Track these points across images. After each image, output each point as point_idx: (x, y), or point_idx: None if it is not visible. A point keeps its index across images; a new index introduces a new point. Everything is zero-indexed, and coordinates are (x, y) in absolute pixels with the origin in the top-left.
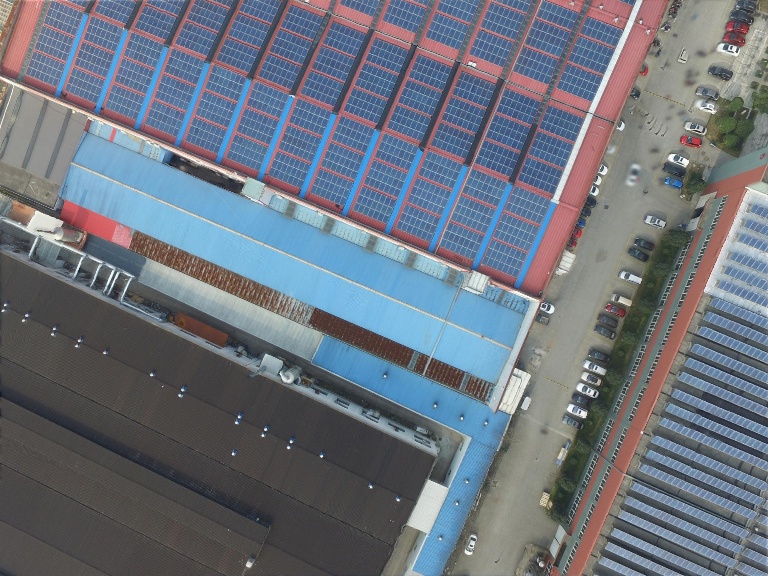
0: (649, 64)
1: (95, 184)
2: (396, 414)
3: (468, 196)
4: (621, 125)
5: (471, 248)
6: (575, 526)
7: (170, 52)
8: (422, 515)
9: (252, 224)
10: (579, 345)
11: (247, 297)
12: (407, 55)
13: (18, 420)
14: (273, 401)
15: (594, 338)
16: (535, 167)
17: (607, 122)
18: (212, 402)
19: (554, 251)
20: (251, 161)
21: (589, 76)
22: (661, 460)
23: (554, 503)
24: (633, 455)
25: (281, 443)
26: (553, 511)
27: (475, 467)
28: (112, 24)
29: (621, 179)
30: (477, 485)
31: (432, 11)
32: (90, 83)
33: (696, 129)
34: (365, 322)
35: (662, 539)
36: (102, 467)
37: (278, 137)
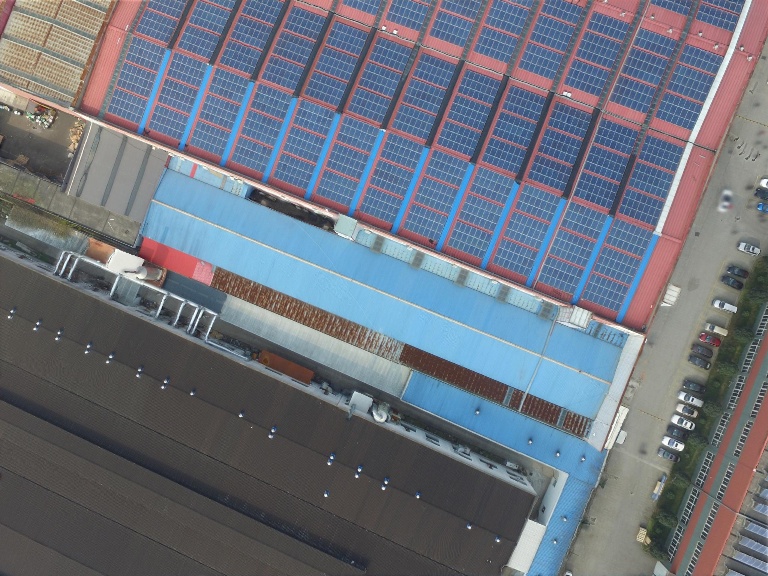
0: None
1: (177, 221)
2: (485, 449)
3: (567, 229)
4: None
5: (570, 282)
6: (679, 564)
7: (256, 87)
8: (520, 554)
9: (339, 259)
10: (672, 376)
11: (333, 333)
12: (499, 86)
13: (104, 464)
14: (366, 440)
15: (688, 368)
16: (636, 199)
17: (708, 151)
18: (303, 442)
19: (657, 284)
20: (341, 197)
21: (689, 105)
22: None
23: (652, 539)
24: (746, 493)
25: (375, 484)
26: (653, 548)
27: (572, 504)
28: (196, 60)
29: (712, 205)
30: (574, 522)
31: (524, 41)
32: (174, 120)
33: None
34: (457, 358)
35: None
36: (192, 511)
37: (369, 172)
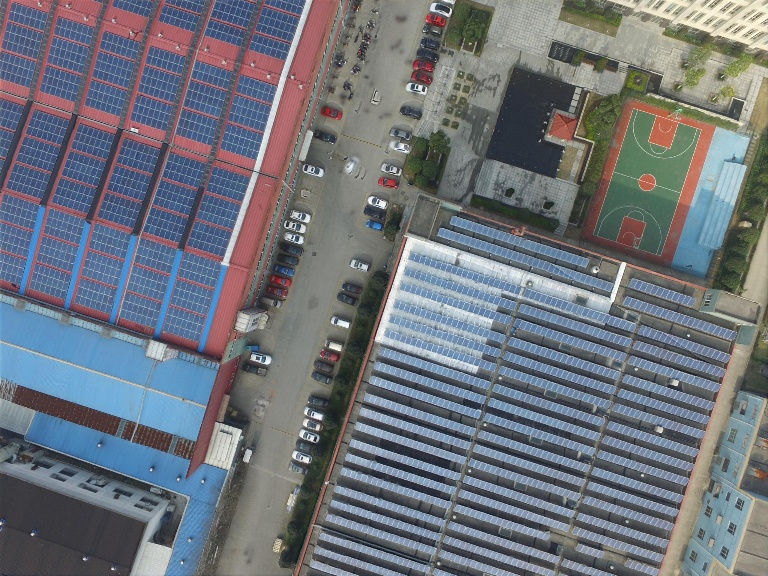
0: (343, 108)
1: None
2: None
3: (141, 265)
4: (319, 172)
5: (151, 316)
6: None
7: None
8: None
9: None
10: (299, 392)
11: None
12: (68, 125)
13: None
14: None
15: (313, 384)
16: (204, 231)
17: (273, 179)
18: None
19: (231, 313)
20: None
21: (250, 135)
22: (344, 508)
23: (285, 549)
24: (320, 505)
25: None
26: (280, 558)
27: (197, 525)
28: None
29: (326, 225)
30: (202, 542)
31: (88, 78)
32: None
33: (390, 171)
34: (69, 395)
35: None
36: None
37: None
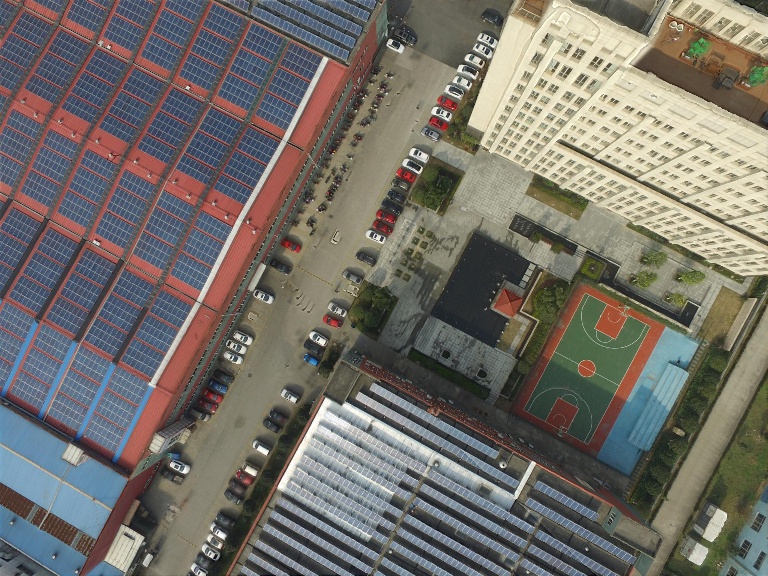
0: (304, 242)
1: None
2: None
3: (76, 370)
4: (268, 299)
5: (76, 419)
6: None
7: None
8: None
9: None
10: (210, 506)
11: None
12: (39, 228)
13: None
14: None
15: (225, 501)
16: (139, 350)
17: (213, 312)
18: None
19: (149, 431)
20: None
21: (200, 267)
22: None
23: None
24: None
25: None
26: None
27: None
28: None
29: (266, 350)
30: None
31: (65, 188)
32: None
33: (335, 311)
34: None
35: None
36: None
37: None
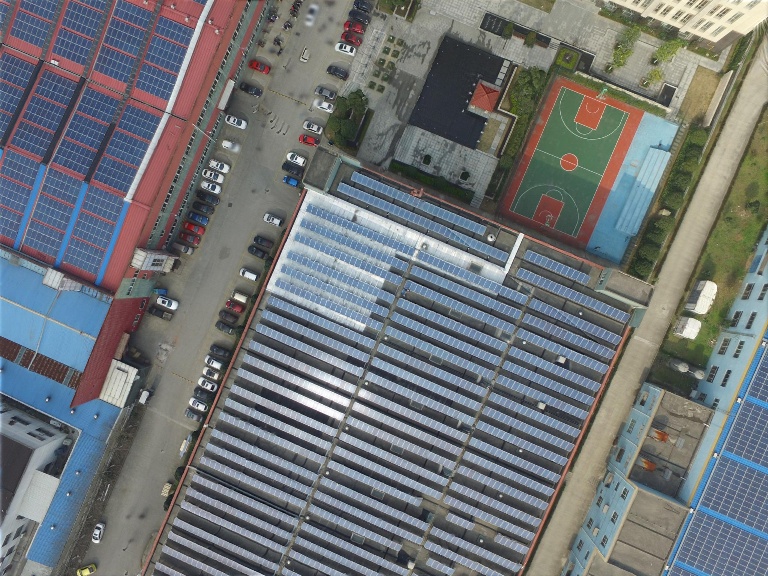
0: (272, 63)
1: None
2: (31, 408)
3: (47, 194)
4: (241, 124)
5: (53, 246)
6: None
7: None
8: (33, 505)
9: None
10: (203, 340)
11: None
12: None
13: None
14: None
15: (217, 333)
16: (110, 166)
17: (184, 122)
18: None
19: (130, 249)
20: None
21: (165, 76)
22: (219, 452)
23: (173, 493)
24: (197, 447)
25: None
26: (165, 501)
27: (87, 459)
28: None
29: (244, 177)
30: (90, 476)
31: (15, 8)
32: None
33: (311, 128)
34: None
35: (222, 528)
36: None
37: None
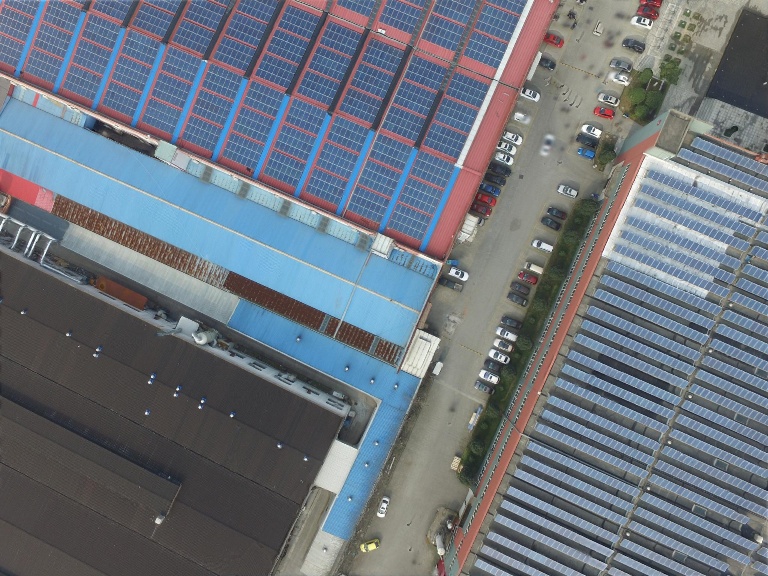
0: (565, 36)
1: (17, 148)
2: (313, 379)
3: (375, 160)
4: (536, 96)
5: (377, 211)
6: (480, 488)
7: (87, 17)
8: (332, 476)
9: (169, 188)
10: (492, 312)
11: (165, 261)
12: (318, 22)
13: None
14: (186, 362)
15: (507, 305)
16: (440, 132)
17: (512, 89)
18: (126, 362)
19: (458, 215)
20: (165, 125)
21: (495, 44)
22: (556, 420)
23: (464, 467)
24: (530, 415)
25: (193, 403)
26: (461, 474)
27: (385, 429)
28: None
29: (536, 149)
30: (387, 447)
31: None
32: (10, 47)
33: (609, 100)
34: (278, 285)
35: (557, 498)
36: (17, 424)
37: (191, 101)
